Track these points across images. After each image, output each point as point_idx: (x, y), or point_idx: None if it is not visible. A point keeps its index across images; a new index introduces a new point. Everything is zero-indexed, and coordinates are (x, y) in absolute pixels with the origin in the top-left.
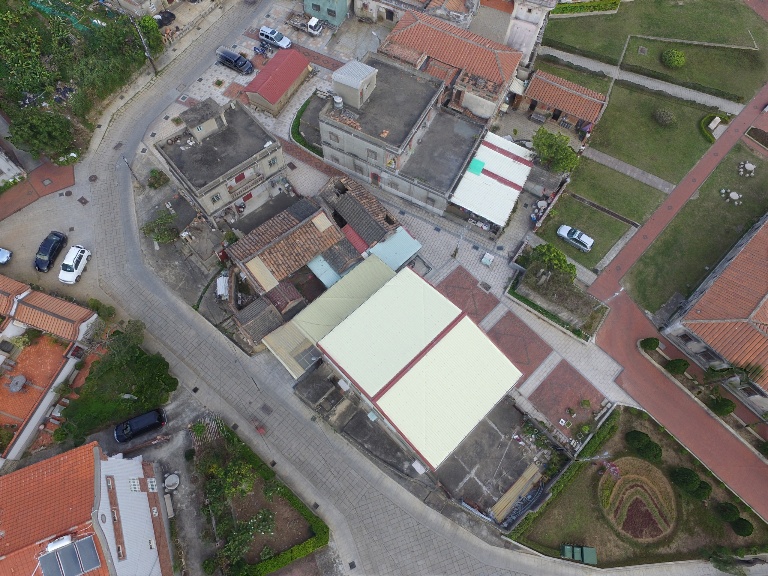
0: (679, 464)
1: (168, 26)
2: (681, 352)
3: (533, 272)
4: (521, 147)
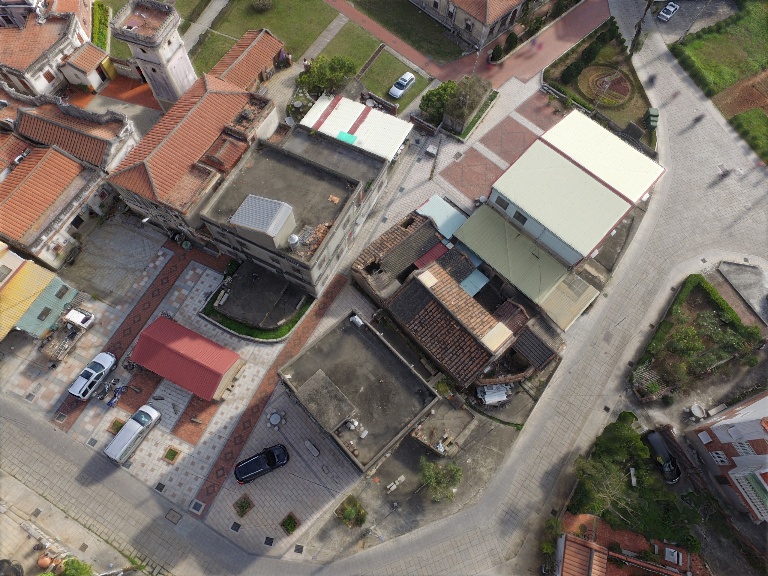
0: (575, 59)
1: (24, 569)
2: (494, 41)
3: (458, 108)
4: (317, 101)
